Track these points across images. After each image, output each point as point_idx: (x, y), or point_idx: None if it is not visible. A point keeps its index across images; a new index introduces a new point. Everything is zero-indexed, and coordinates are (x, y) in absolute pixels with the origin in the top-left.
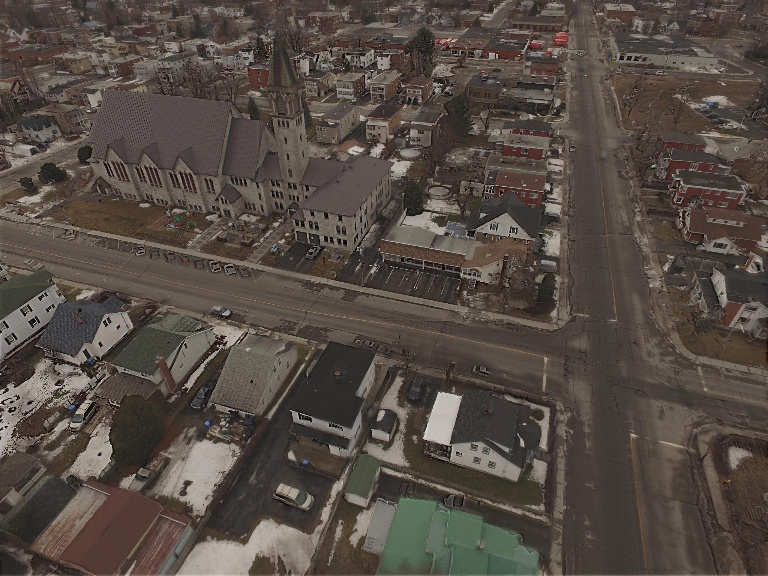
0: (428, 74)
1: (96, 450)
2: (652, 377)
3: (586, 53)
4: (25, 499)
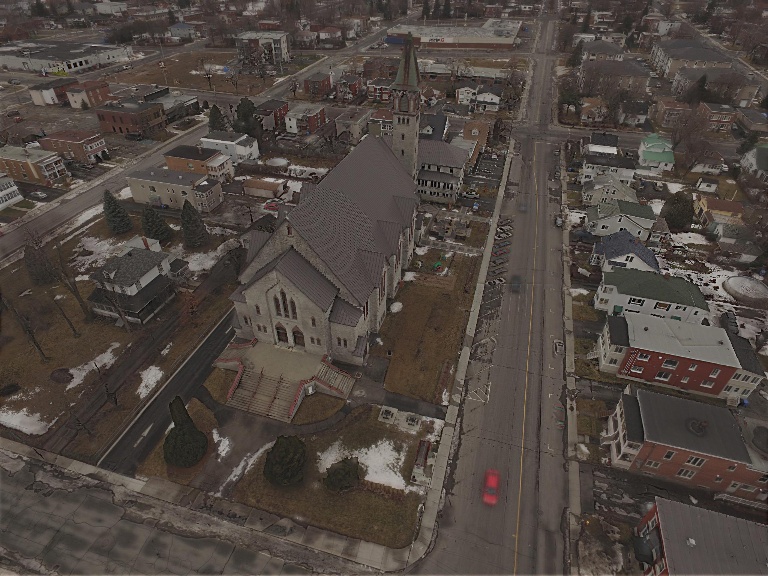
0: (4, 139)
1: (689, 239)
2: (536, 127)
3: (0, 77)
4: (738, 231)
